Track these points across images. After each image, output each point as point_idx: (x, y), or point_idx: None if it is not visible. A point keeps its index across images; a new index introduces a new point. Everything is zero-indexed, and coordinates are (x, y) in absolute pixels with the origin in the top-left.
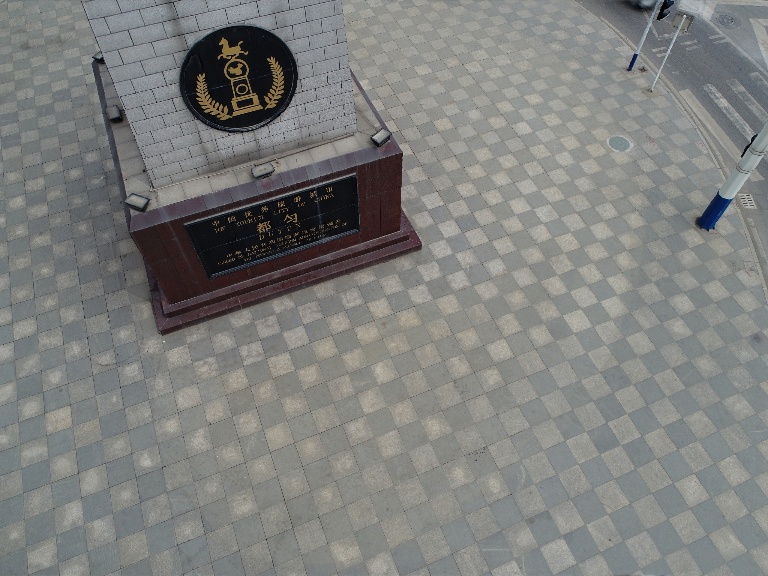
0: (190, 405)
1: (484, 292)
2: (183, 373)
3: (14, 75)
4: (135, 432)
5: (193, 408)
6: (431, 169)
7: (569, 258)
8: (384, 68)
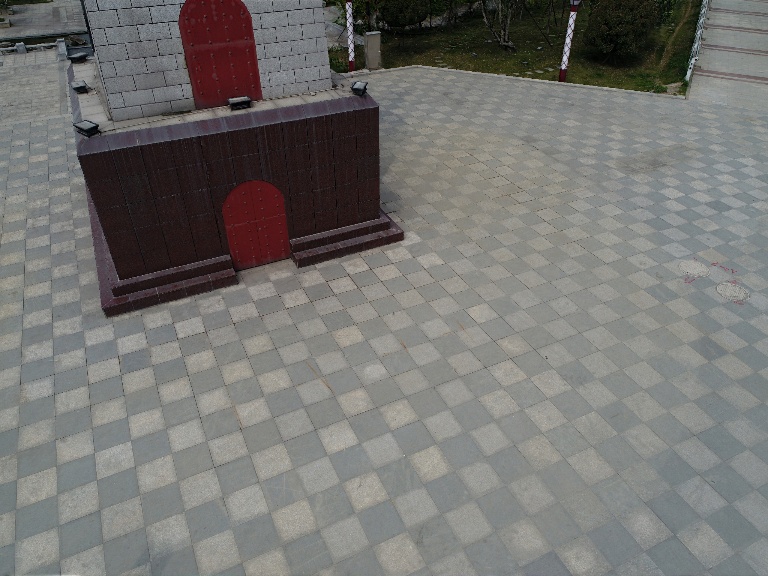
0: (8, 200)
1: (3, 375)
2: (42, 194)
3: (408, 96)
4: (3, 183)
5: (4, 202)
6: (252, 325)
7: (3, 485)
8: (474, 276)
